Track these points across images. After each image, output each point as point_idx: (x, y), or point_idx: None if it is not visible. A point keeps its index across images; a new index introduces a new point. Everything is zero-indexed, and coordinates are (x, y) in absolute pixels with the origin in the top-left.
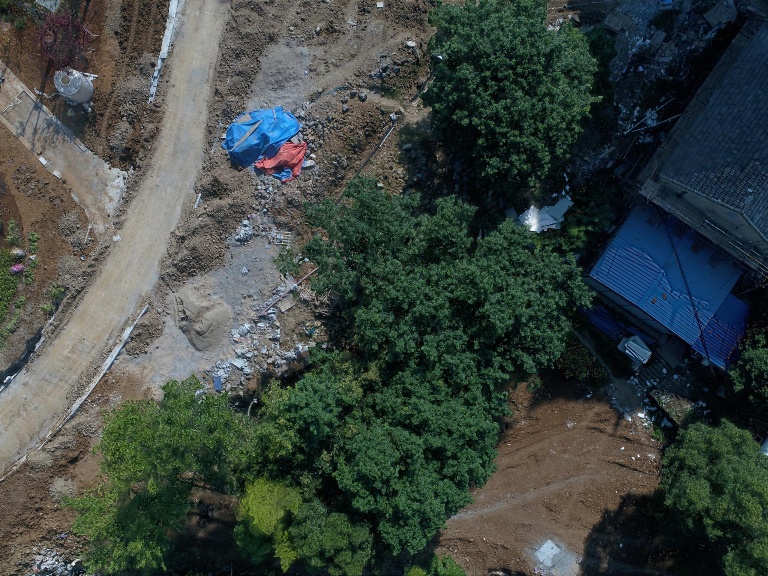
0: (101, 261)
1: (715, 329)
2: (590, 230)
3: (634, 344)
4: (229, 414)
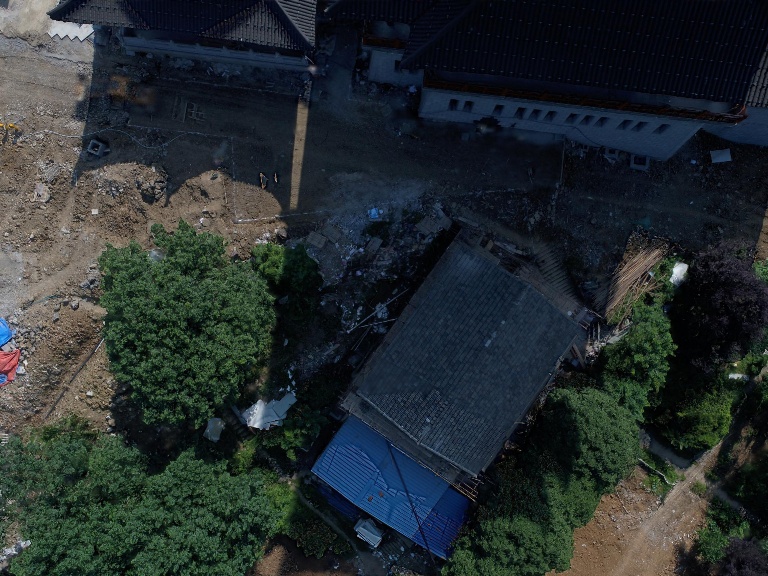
0: None
1: (435, 522)
2: (304, 433)
3: (364, 530)
4: None
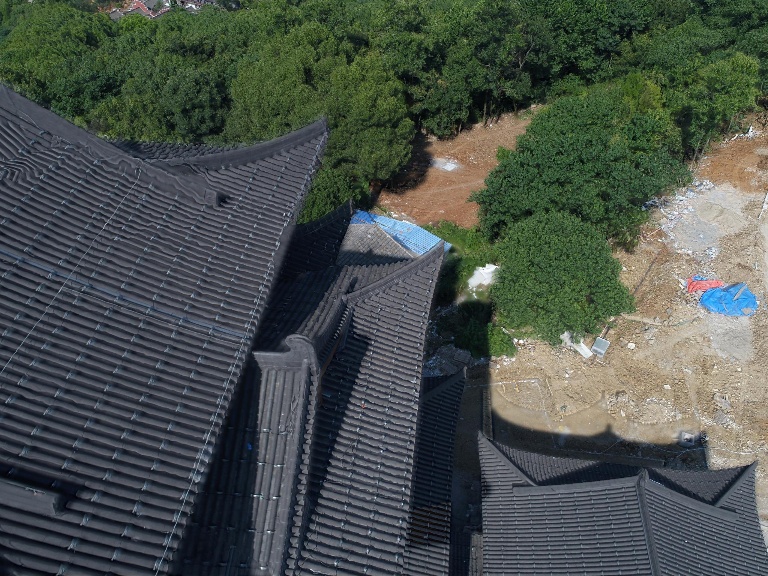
0: None
1: None
2: None
3: None
4: (692, 105)
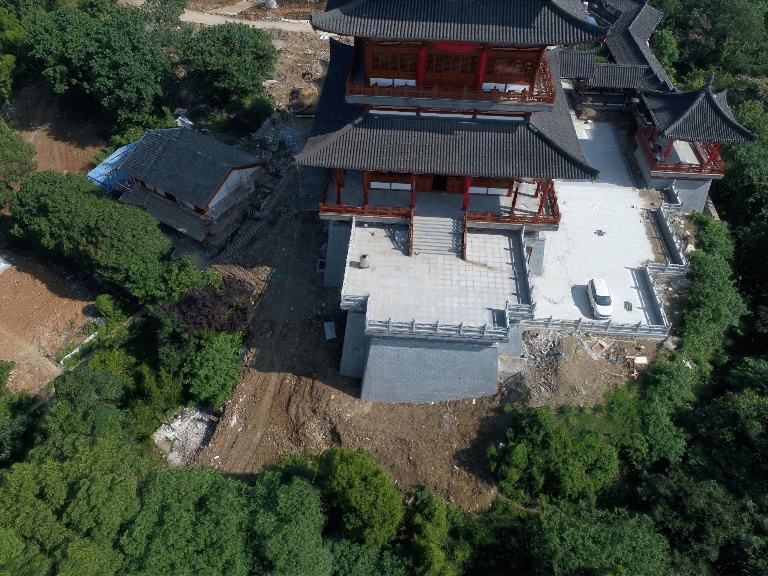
0: (198, 11)
1: None
2: None
3: None
4: None
